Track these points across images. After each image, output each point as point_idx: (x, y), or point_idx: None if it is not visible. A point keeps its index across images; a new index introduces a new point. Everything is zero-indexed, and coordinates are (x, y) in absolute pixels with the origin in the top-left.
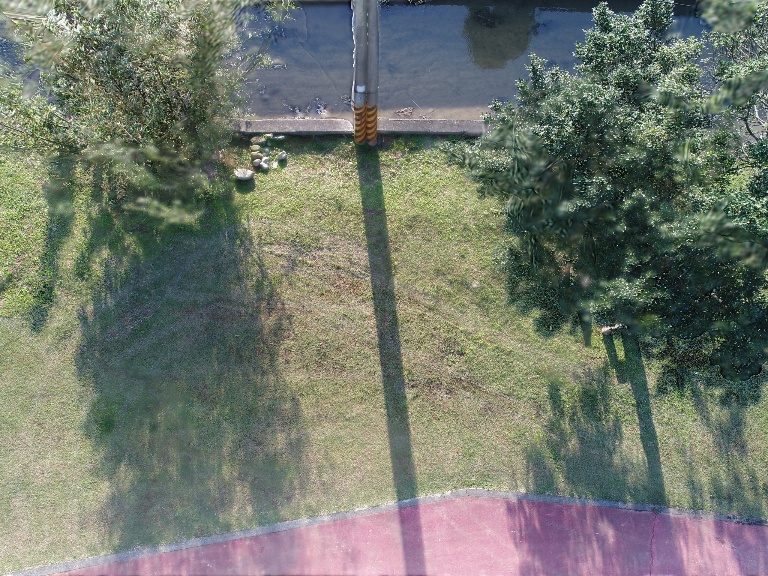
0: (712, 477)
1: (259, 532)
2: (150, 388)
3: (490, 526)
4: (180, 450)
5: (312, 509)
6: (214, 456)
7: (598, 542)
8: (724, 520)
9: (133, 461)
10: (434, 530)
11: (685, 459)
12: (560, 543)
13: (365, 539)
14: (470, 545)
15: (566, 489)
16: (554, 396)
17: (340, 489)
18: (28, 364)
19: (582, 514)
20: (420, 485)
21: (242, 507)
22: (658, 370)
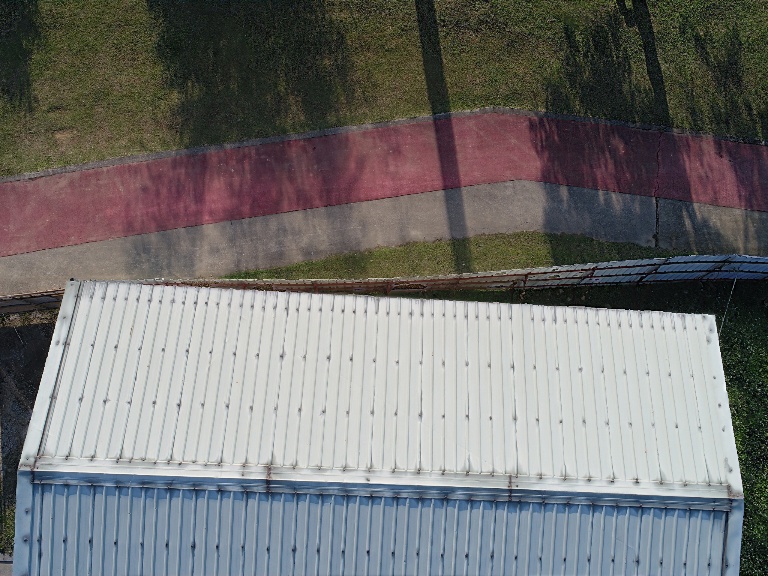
0: (711, 105)
1: (311, 135)
2: (213, 21)
3: (514, 137)
4: (240, 71)
5: (357, 119)
6: (270, 76)
7: (610, 153)
8: (722, 139)
9: (199, 79)
10: (465, 138)
11: (687, 90)
12: (577, 152)
13: (404, 143)
14: (497, 151)
15: (581, 111)
16: (570, 36)
17: (382, 104)
18: (105, 0)
19: (596, 130)
20: (452, 103)
21: (296, 116)
22: (662, 18)
